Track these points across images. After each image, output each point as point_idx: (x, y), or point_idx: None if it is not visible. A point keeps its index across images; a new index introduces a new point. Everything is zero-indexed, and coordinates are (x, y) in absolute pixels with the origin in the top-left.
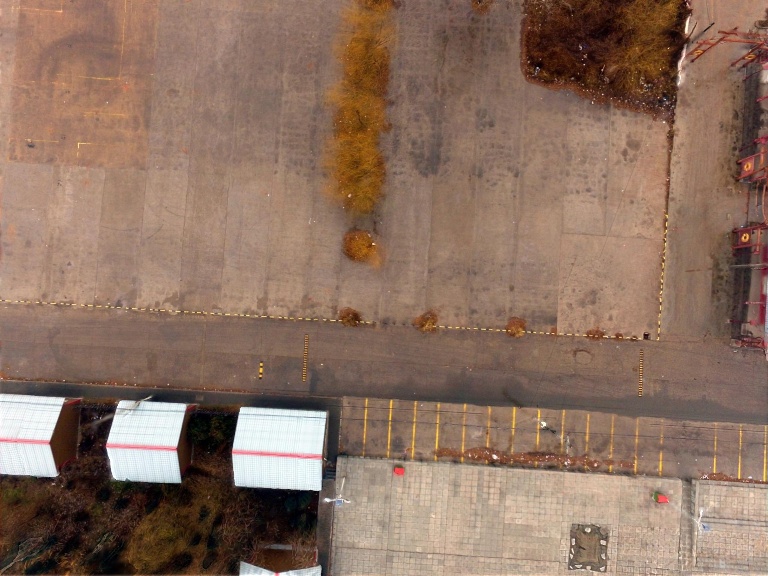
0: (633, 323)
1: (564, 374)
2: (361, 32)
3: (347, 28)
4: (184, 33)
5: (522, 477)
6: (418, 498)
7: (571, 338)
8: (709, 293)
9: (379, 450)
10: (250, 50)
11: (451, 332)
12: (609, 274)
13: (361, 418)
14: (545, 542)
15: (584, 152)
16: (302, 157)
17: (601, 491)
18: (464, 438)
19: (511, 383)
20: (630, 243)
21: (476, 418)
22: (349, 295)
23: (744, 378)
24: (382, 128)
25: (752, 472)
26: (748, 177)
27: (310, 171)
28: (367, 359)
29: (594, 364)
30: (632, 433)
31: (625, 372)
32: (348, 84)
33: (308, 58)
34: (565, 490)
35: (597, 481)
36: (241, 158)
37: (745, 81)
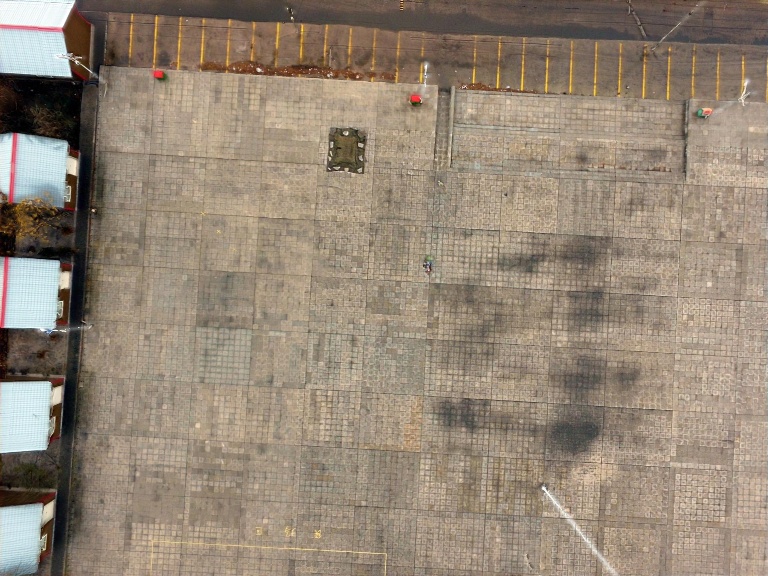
0: None
1: None
2: None
3: None
4: None
5: (282, 83)
6: (180, 104)
7: None
8: None
9: (145, 64)
10: None
11: None
12: None
13: (127, 33)
14: (304, 145)
15: None
16: None
17: (359, 96)
18: (228, 52)
19: None
20: None
21: (240, 33)
22: None
23: None
24: None
25: (510, 82)
26: None
27: None
28: None
29: None
30: (393, 46)
31: None
32: None
33: None
34: (324, 95)
35: (355, 86)
36: None
37: None
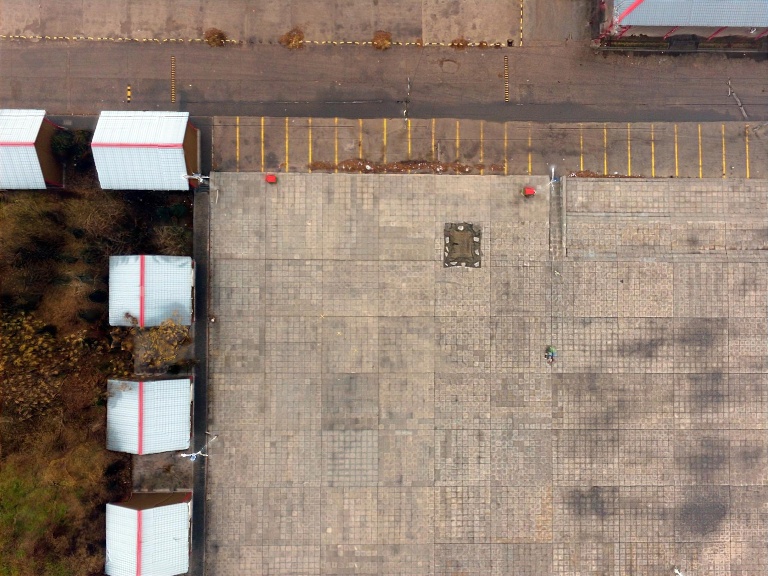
0: (496, 30)
1: (432, 84)
2: None
3: None
4: None
5: (394, 181)
6: (293, 207)
7: (437, 48)
8: None
9: (253, 167)
10: None
11: (318, 48)
12: None
13: (233, 136)
14: (420, 242)
15: None
16: None
17: (472, 190)
18: (337, 151)
19: (380, 95)
20: None
21: (348, 131)
22: (214, 16)
23: (606, 78)
24: None
25: (617, 167)
26: None
27: None
28: (236, 78)
29: (460, 72)
30: (501, 137)
31: (491, 78)
32: None
33: None
34: (437, 191)
35: (467, 181)
36: None
37: None
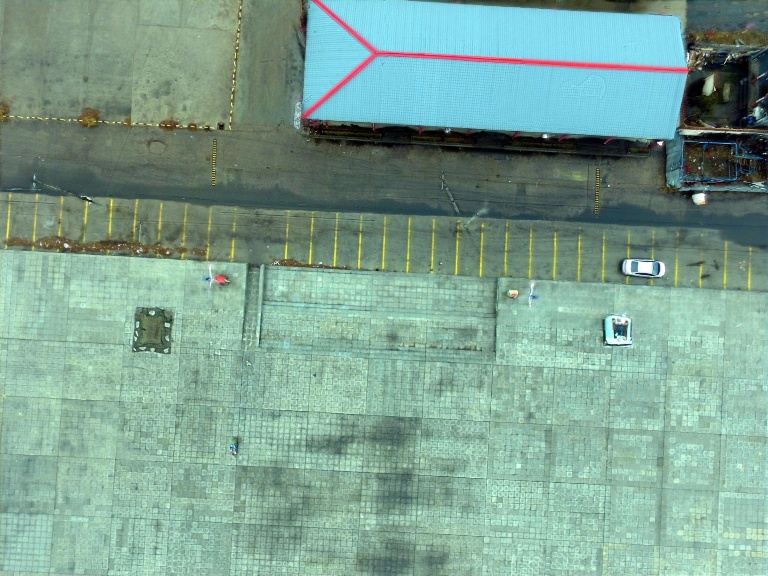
0: (207, 113)
1: (137, 164)
2: None
3: None
4: None
5: (87, 262)
6: None
7: (145, 128)
8: (283, 83)
9: None
10: None
11: (23, 123)
12: (183, 65)
13: None
14: (109, 325)
15: None
16: None
17: (166, 275)
18: (35, 227)
19: (84, 173)
20: (205, 34)
21: (48, 208)
22: None
23: (316, 166)
24: None
25: (322, 258)
26: None
27: None
28: None
29: (167, 154)
30: (205, 221)
31: (198, 161)
32: None
33: None
34: (130, 274)
35: (162, 265)
36: None
37: None
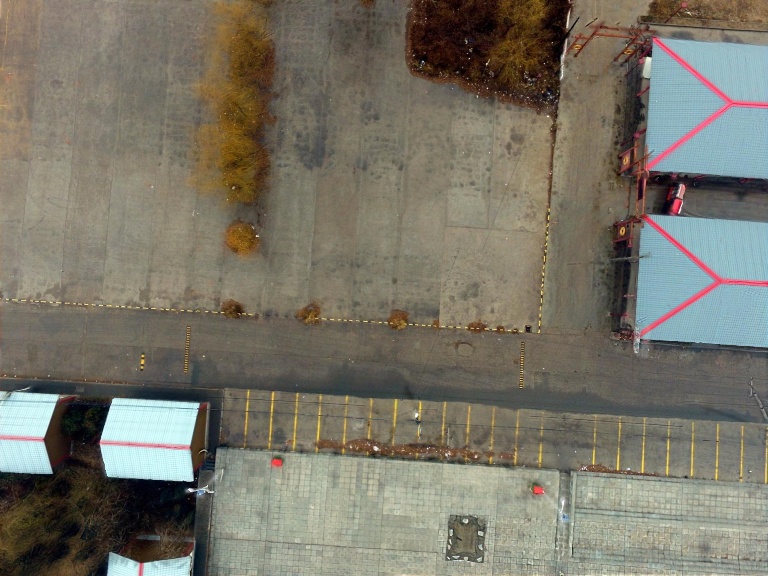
0: (515, 316)
1: (446, 366)
2: (247, 24)
3: (233, 20)
4: (68, 24)
5: (401, 468)
6: (297, 489)
7: (453, 330)
8: (590, 286)
9: (260, 442)
10: (135, 41)
11: (334, 324)
12: (491, 267)
13: (243, 410)
14: (423, 533)
15: (468, 146)
16: (186, 149)
17: (479, 482)
18: (345, 430)
19: (393, 375)
20: (513, 236)
21: (358, 410)
22: (232, 287)
23: (624, 371)
24: (267, 120)
25: (630, 464)
26: (627, 171)
27: (194, 163)
28: (249, 351)
29: (475, 356)
30: (512, 425)
31: (506, 364)
32: (233, 76)
33: (193, 50)
34: (443, 481)
35: (475, 472)
36: (125, 150)
37: (627, 76)
